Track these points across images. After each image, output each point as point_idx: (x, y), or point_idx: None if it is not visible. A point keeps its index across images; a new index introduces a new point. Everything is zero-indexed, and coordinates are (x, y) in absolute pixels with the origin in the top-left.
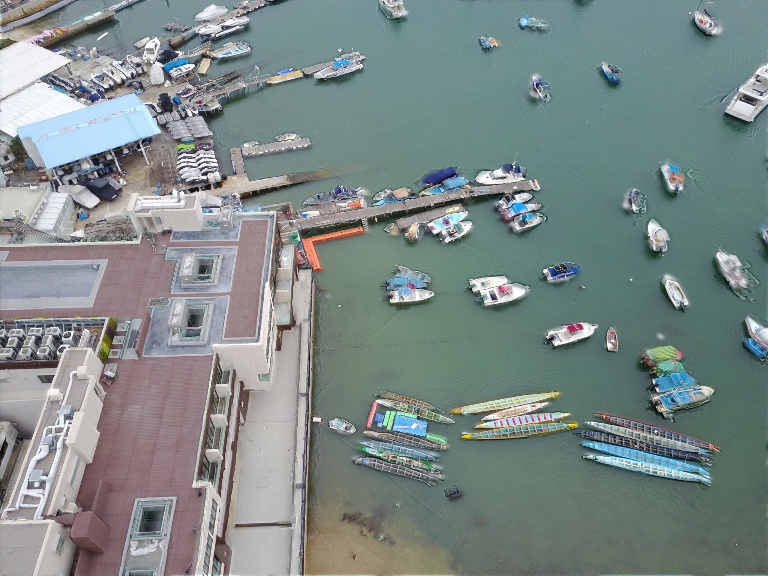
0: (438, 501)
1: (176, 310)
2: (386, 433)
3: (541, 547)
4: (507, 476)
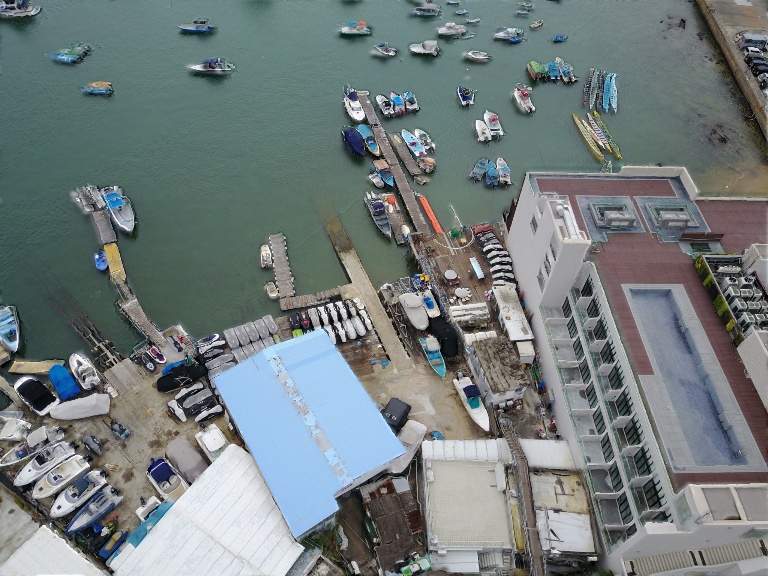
0: None
1: None
2: None
3: (676, 138)
4: (638, 145)
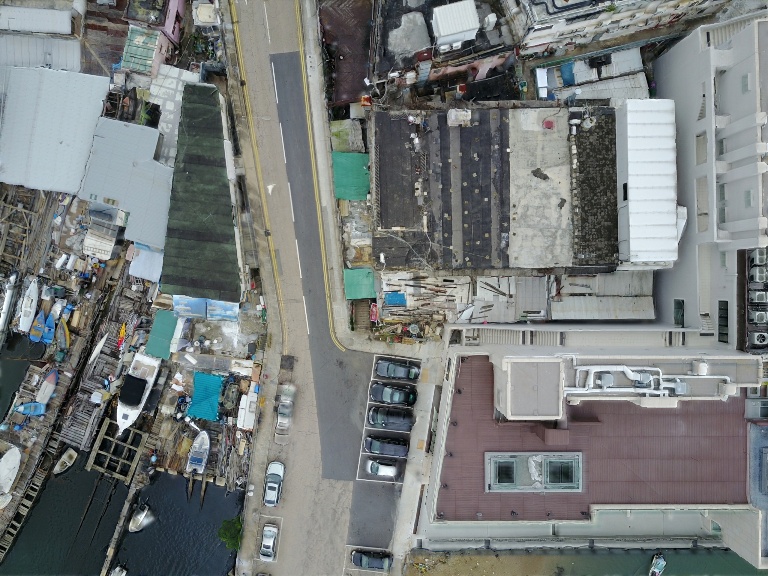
0: None
1: None
2: None
3: None
4: None
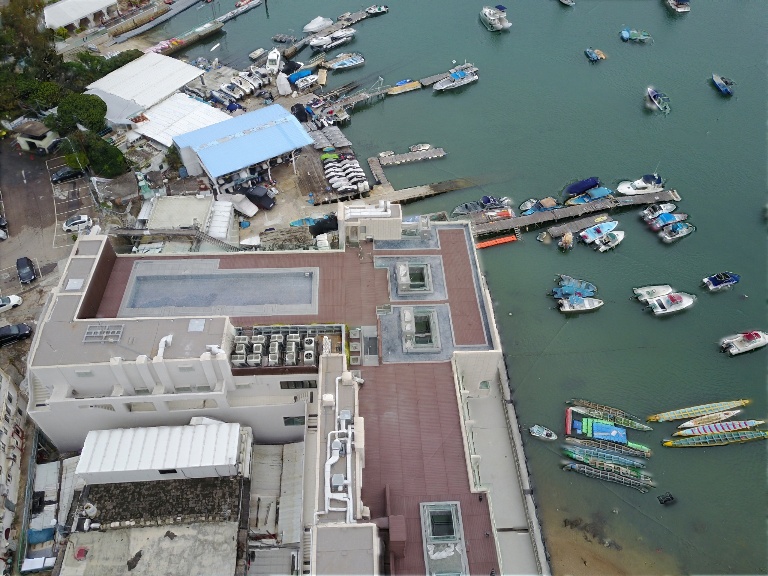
0: (653, 508)
1: (406, 317)
2: (588, 440)
3: (766, 554)
4: (715, 483)
